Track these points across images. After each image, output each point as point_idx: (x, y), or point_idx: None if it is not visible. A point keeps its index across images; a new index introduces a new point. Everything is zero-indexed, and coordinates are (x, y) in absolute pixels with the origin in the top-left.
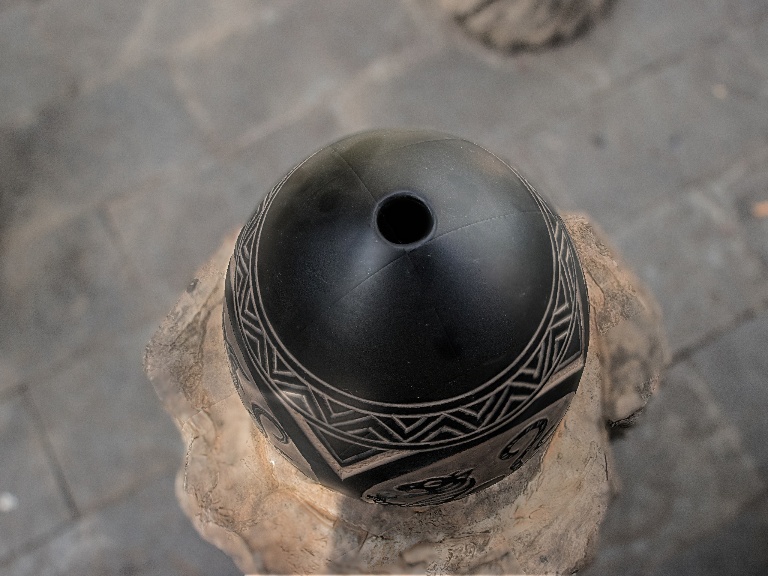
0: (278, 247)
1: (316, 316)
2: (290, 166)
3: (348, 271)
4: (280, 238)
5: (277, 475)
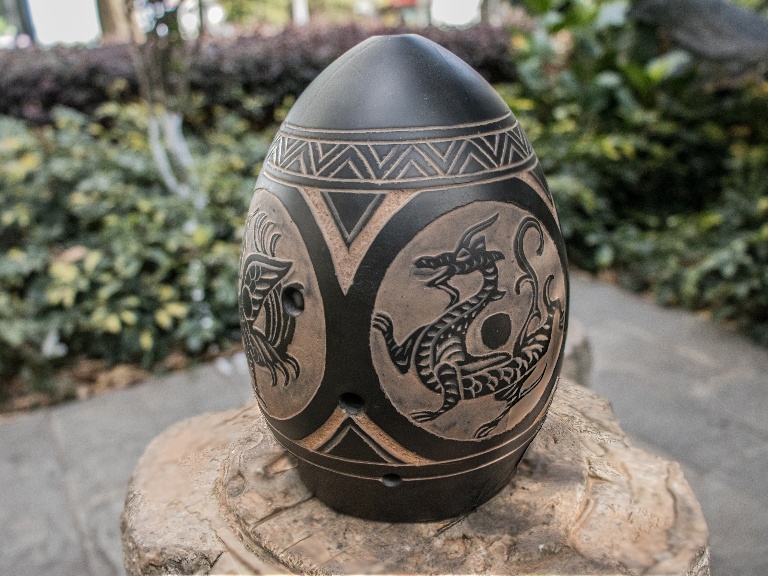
0: (402, 95)
1: (459, 82)
2: (294, 175)
3: (430, 52)
4: (394, 94)
5: (555, 541)
